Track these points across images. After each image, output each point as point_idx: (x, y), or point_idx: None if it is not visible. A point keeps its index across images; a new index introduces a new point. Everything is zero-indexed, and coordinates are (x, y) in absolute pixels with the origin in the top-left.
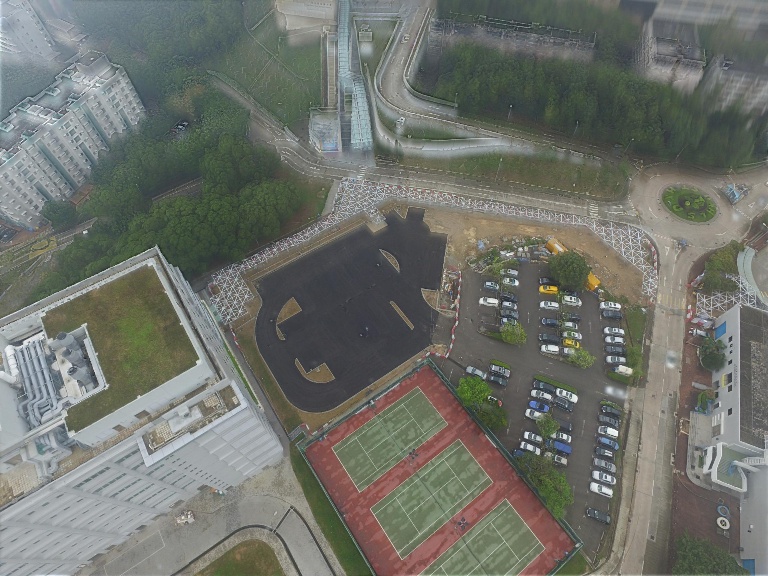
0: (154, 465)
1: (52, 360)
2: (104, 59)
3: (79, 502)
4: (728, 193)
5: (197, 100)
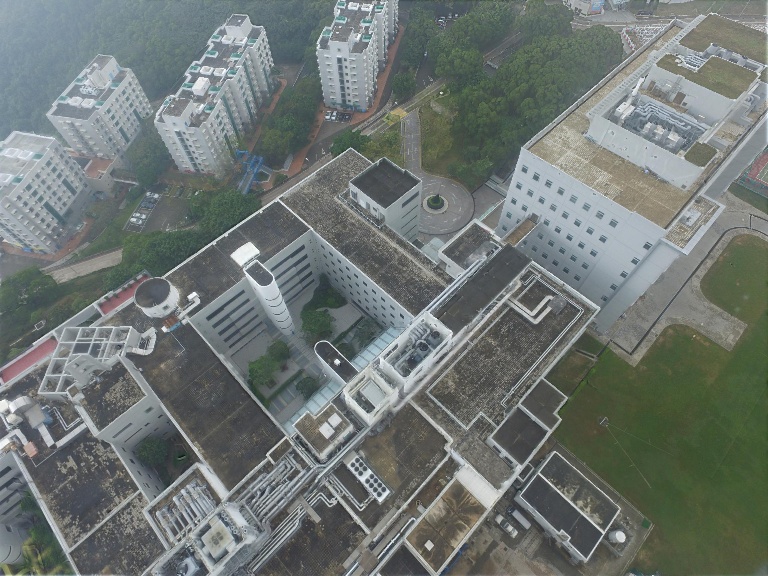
0: None
1: None
2: None
3: None
4: None
5: None
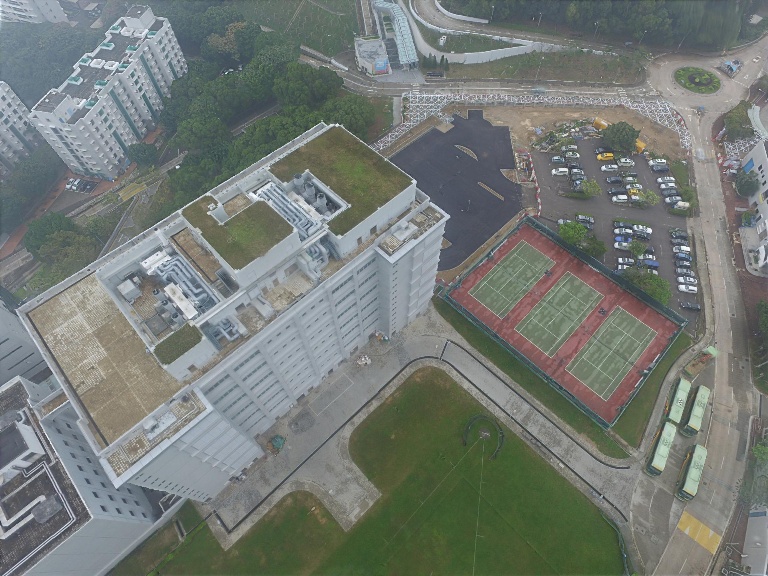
0: (367, 288)
1: None
2: (150, 12)
3: (323, 316)
4: (726, 70)
5: (242, 45)
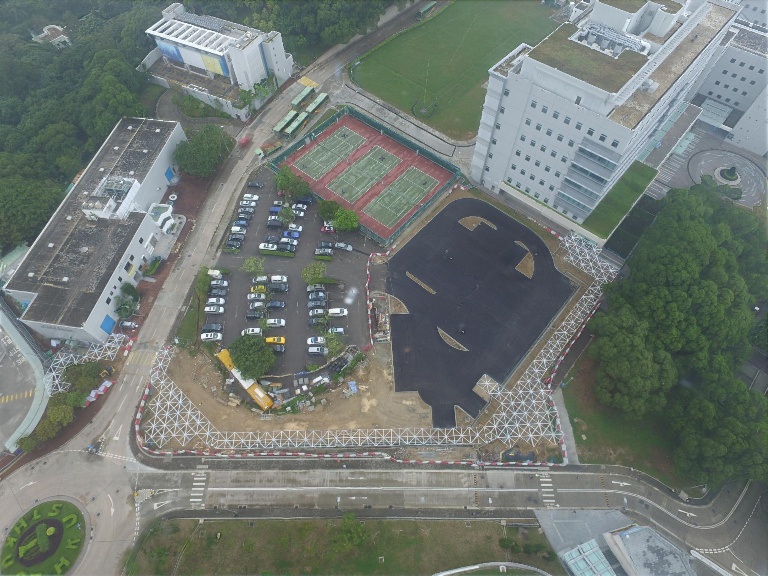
0: None
1: None
2: None
3: None
4: None
5: None
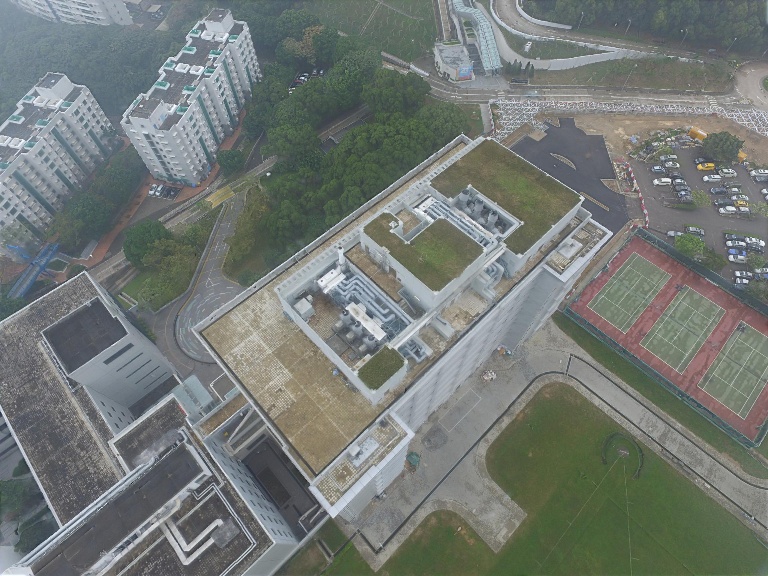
0: None
1: None
2: (230, 16)
3: None
4: None
5: (319, 49)
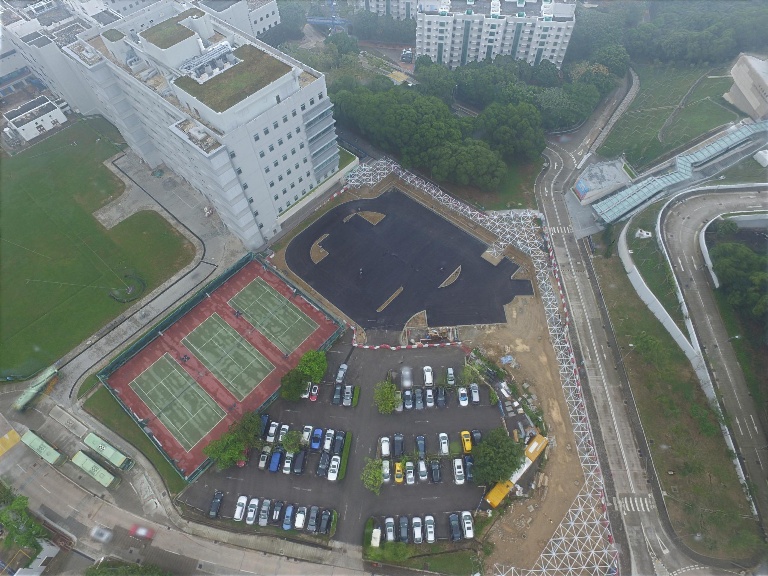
0: None
1: (224, 62)
2: (572, 7)
3: None
4: None
5: None
